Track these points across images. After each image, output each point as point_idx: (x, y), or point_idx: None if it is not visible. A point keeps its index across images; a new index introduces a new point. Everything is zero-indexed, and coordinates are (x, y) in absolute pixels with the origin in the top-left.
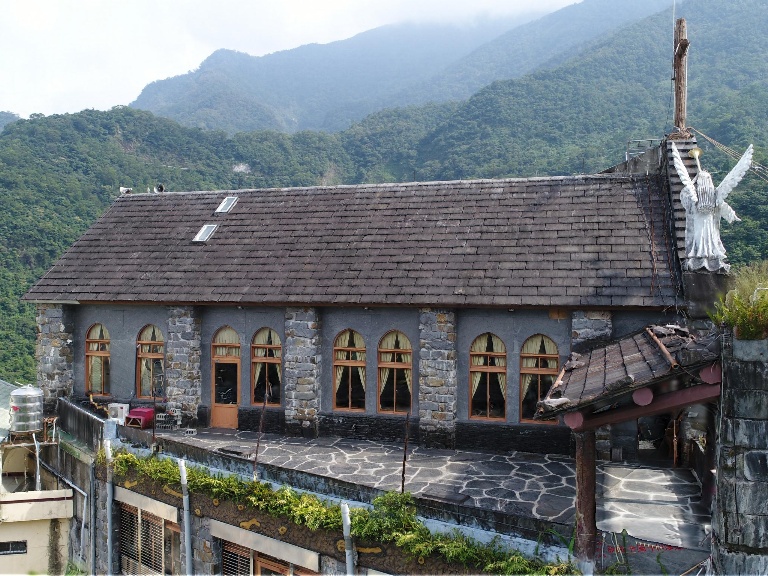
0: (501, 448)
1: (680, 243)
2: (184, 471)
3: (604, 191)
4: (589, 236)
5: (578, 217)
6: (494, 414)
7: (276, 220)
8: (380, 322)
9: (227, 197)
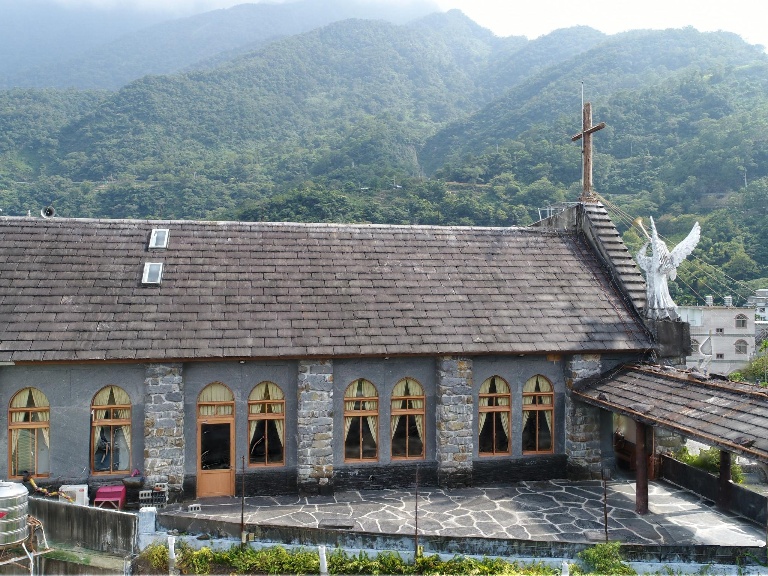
0: (511, 480)
1: (632, 294)
2: (325, 558)
3: (542, 244)
4: (555, 286)
5: (536, 267)
6: None
7: (234, 260)
8: (394, 370)
9: (154, 229)
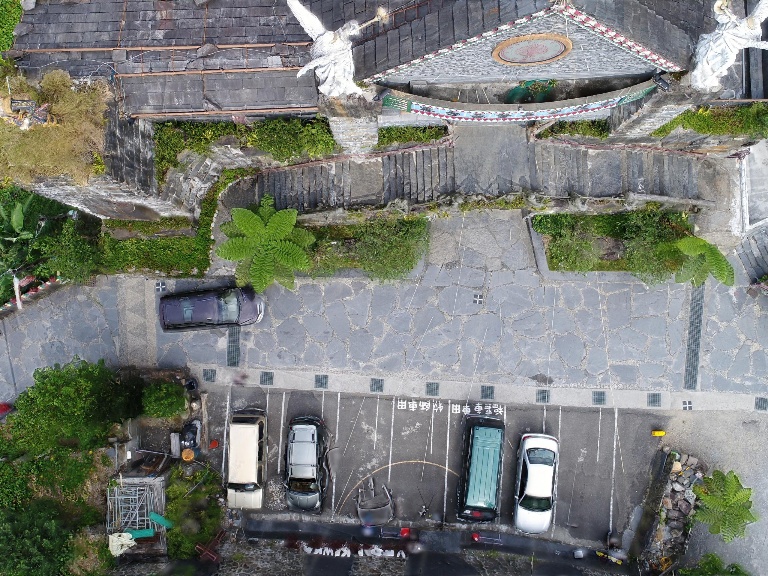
0: None
1: (371, 43)
2: None
3: None
4: None
5: None
6: None
7: None
8: None
9: None
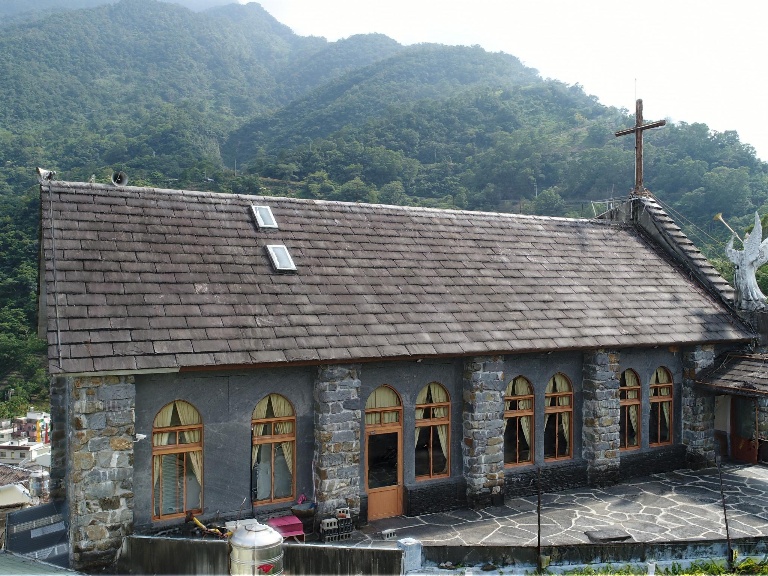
0: (644, 474)
1: None
2: None
3: (616, 236)
4: (652, 278)
5: (625, 259)
6: (629, 444)
7: (356, 244)
8: (548, 366)
9: None
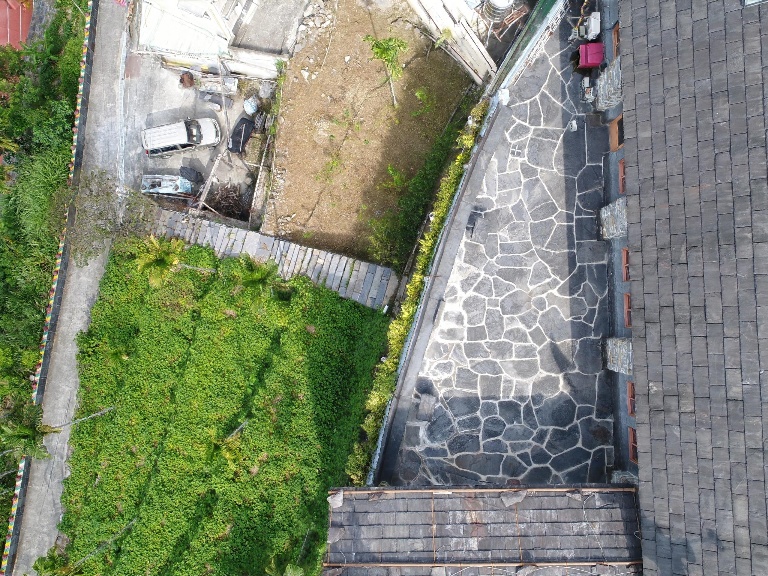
0: None
1: None
2: (432, 218)
3: None
4: None
5: None
6: None
7: None
8: None
9: None
